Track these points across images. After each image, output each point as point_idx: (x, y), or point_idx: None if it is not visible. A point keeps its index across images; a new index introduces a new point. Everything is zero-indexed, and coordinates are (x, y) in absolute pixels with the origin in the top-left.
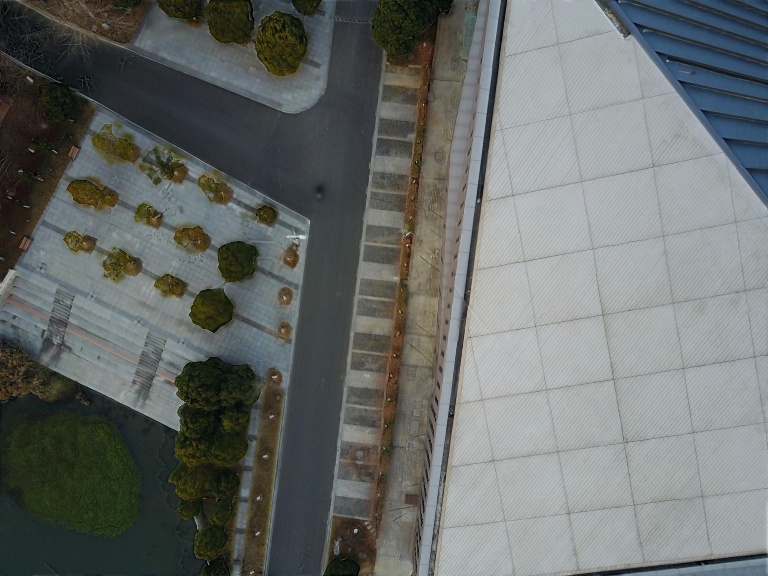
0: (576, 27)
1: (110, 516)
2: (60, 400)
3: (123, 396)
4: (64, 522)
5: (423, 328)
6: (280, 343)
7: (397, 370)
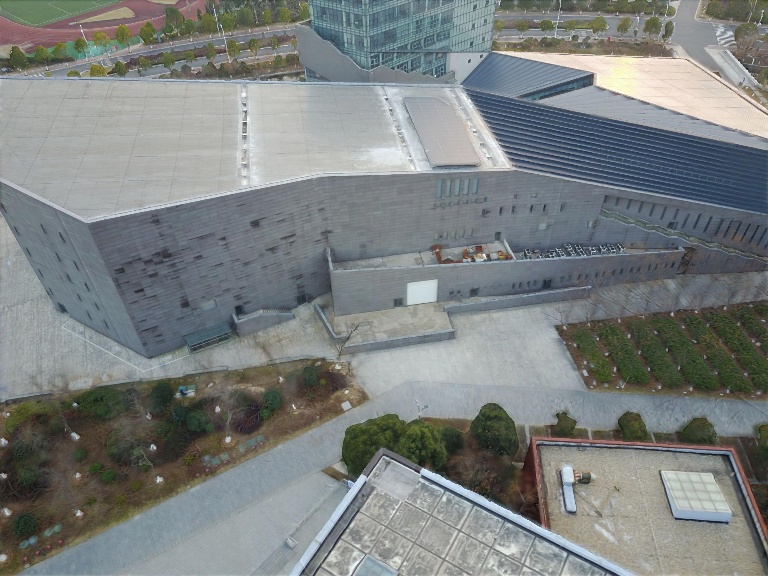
0: None
1: None
2: None
3: None
4: None
5: None
6: None
7: None
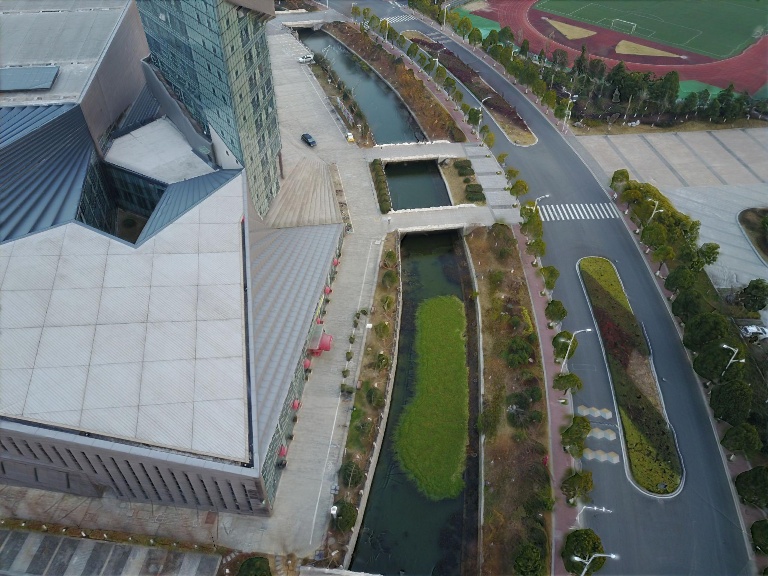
0: None
1: None
2: None
3: None
4: None
5: (52, 506)
6: None
7: None
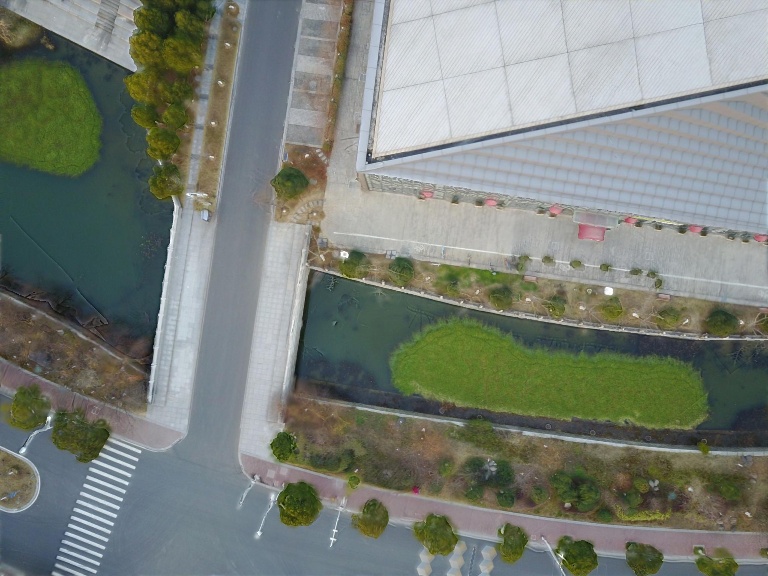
0: None
1: (72, 156)
2: (26, 45)
3: (86, 40)
4: (27, 161)
5: None
6: None
7: (351, 3)
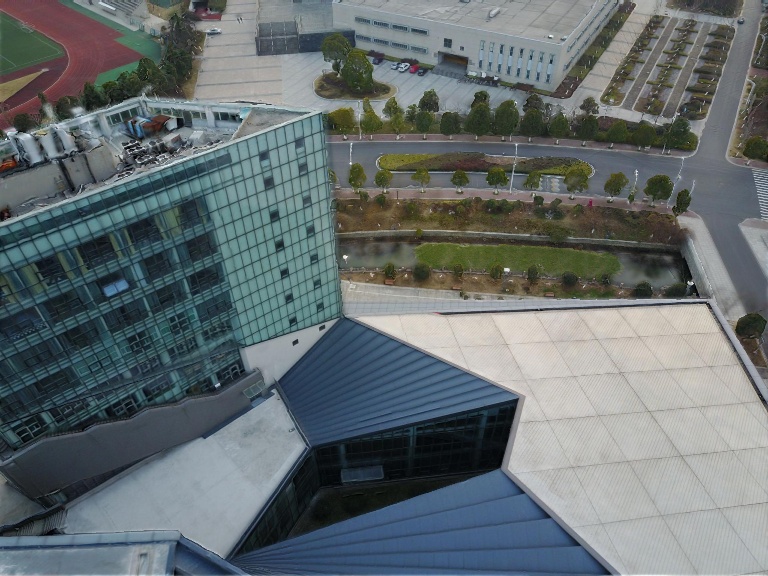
0: None
1: None
2: None
3: None
4: None
5: None
6: None
7: None
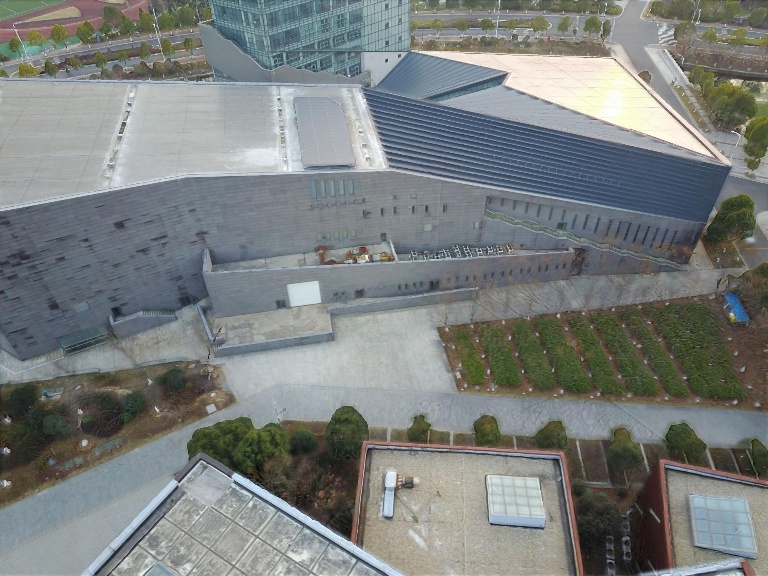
0: (657, 132)
1: None
2: None
3: None
4: None
5: None
6: (712, 140)
7: None
